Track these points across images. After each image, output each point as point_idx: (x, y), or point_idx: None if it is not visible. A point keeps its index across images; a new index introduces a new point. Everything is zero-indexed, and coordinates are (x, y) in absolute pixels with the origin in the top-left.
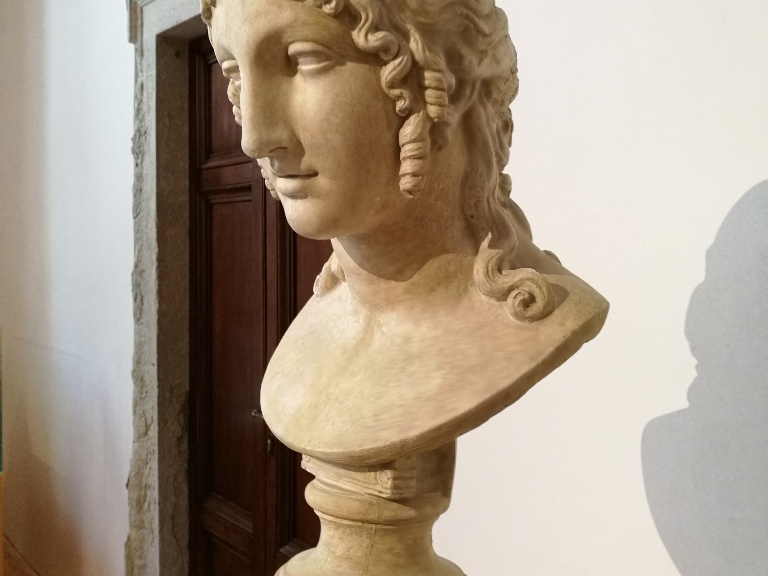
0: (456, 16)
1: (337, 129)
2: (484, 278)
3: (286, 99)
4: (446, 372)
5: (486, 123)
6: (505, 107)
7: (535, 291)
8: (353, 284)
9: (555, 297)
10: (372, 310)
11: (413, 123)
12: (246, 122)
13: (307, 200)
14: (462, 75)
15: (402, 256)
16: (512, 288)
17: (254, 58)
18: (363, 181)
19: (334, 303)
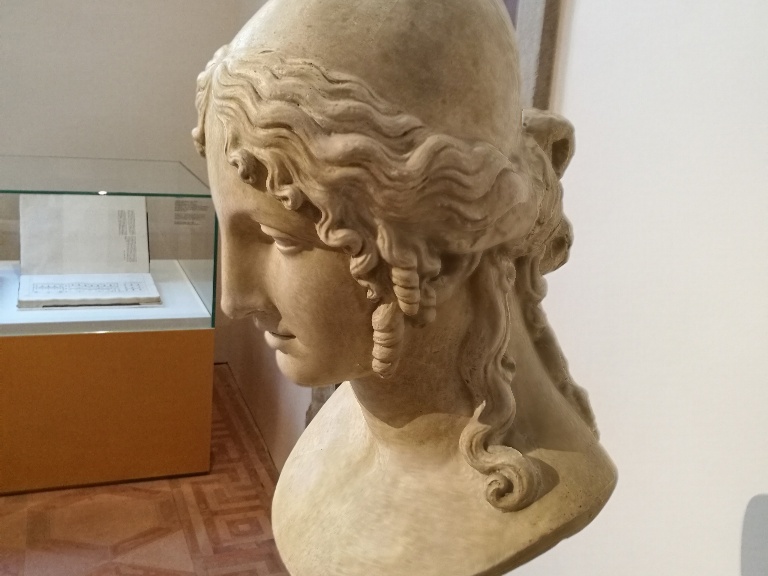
0: (436, 208)
1: (305, 308)
2: (466, 452)
3: (262, 267)
4: (410, 541)
5: (498, 282)
6: None
7: (514, 480)
8: (360, 406)
9: (541, 484)
10: (374, 436)
11: (382, 313)
12: (223, 286)
13: (288, 356)
14: (454, 252)
15: (393, 407)
16: (493, 469)
17: (229, 227)
18: (338, 352)
19: None
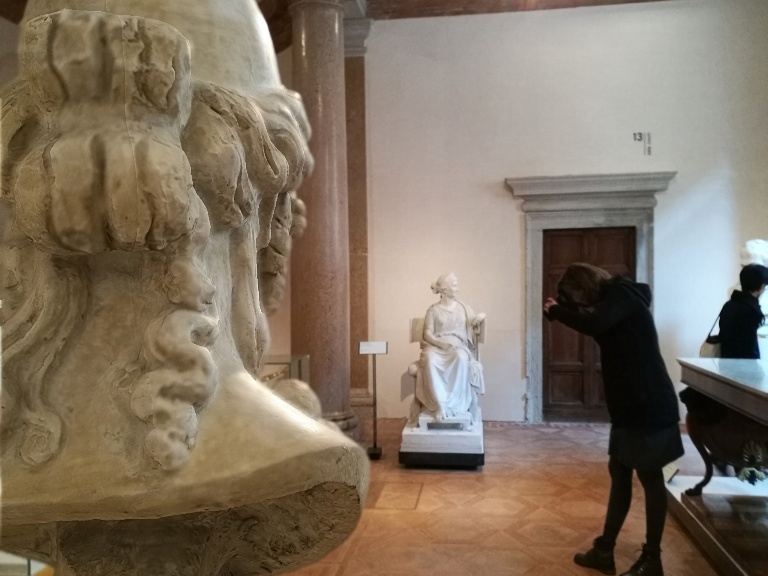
0: None
1: None
2: None
3: None
4: None
5: None
6: (2, 199)
7: None
8: None
9: None
10: None
11: None
12: None
13: None
14: None
15: None
16: None
17: None
18: None
19: None
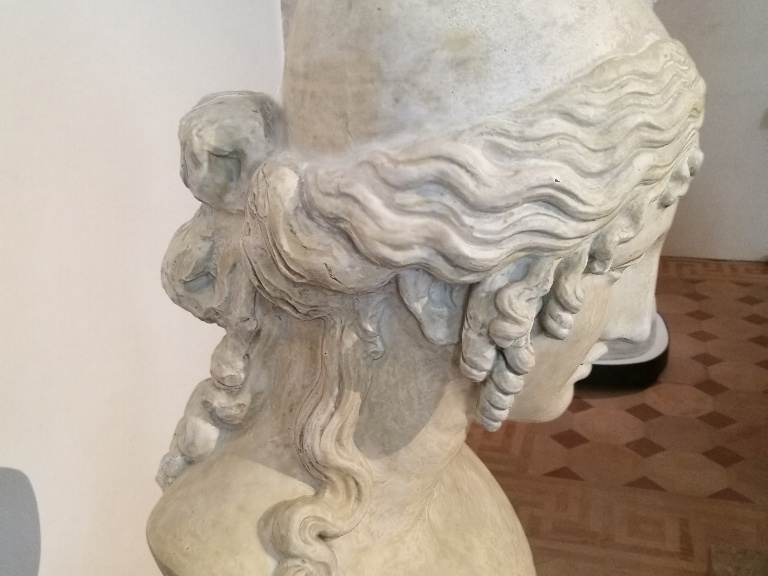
0: None
1: None
2: None
3: None
4: (465, 465)
5: None
6: None
7: None
8: None
9: None
10: None
11: None
12: None
13: None
14: None
15: None
16: None
17: None
18: None
19: (365, 562)
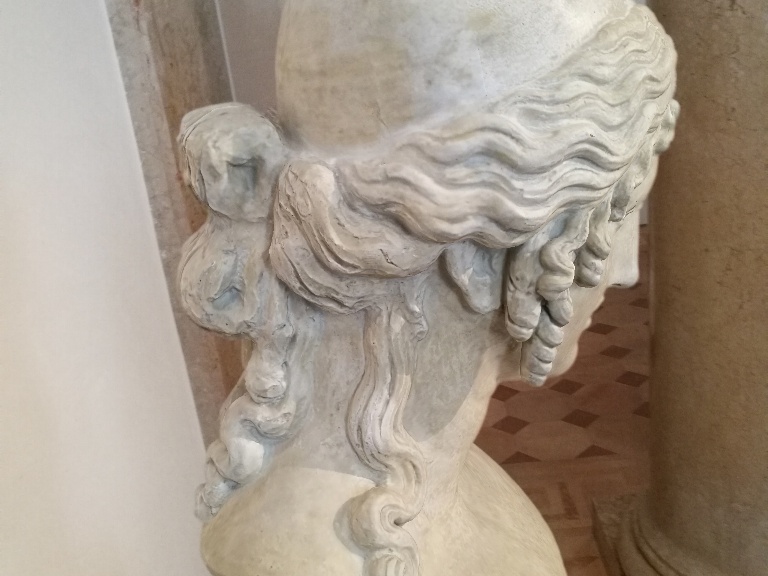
0: None
1: None
2: None
3: None
4: None
5: None
6: None
7: None
8: None
9: None
10: None
11: None
12: None
13: None
14: None
15: None
16: None
17: None
18: None
19: (430, 543)
